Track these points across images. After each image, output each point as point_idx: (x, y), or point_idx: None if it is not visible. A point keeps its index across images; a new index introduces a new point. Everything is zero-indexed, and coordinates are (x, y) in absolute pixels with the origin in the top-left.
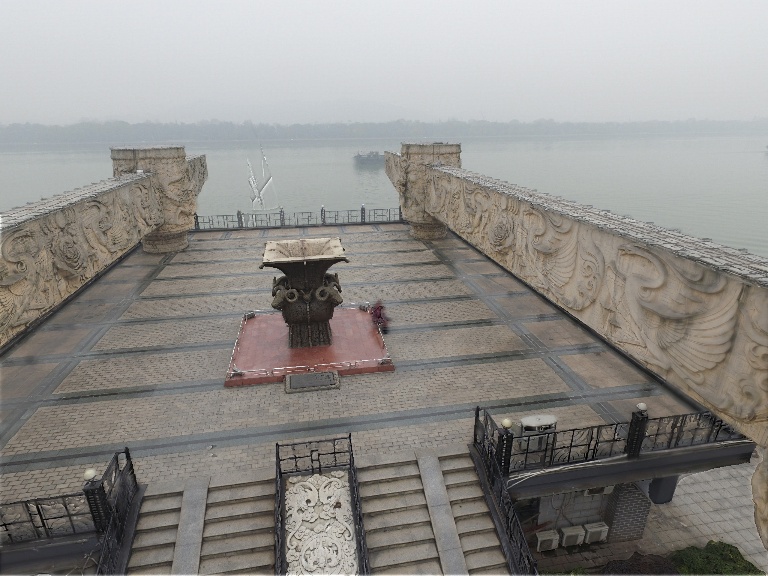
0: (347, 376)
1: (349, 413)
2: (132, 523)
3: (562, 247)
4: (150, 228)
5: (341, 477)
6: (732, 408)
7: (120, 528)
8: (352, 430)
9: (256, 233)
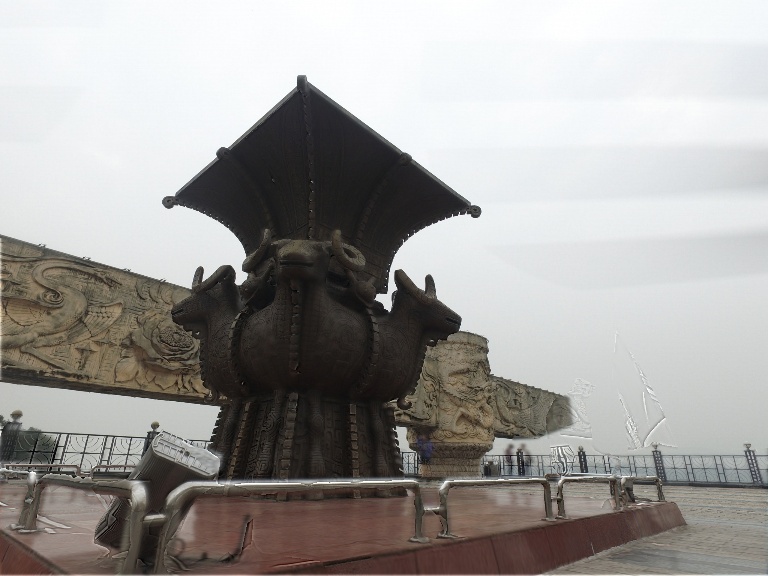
0: None
1: None
2: None
3: None
4: None
5: None
6: None
7: None
8: None
9: None
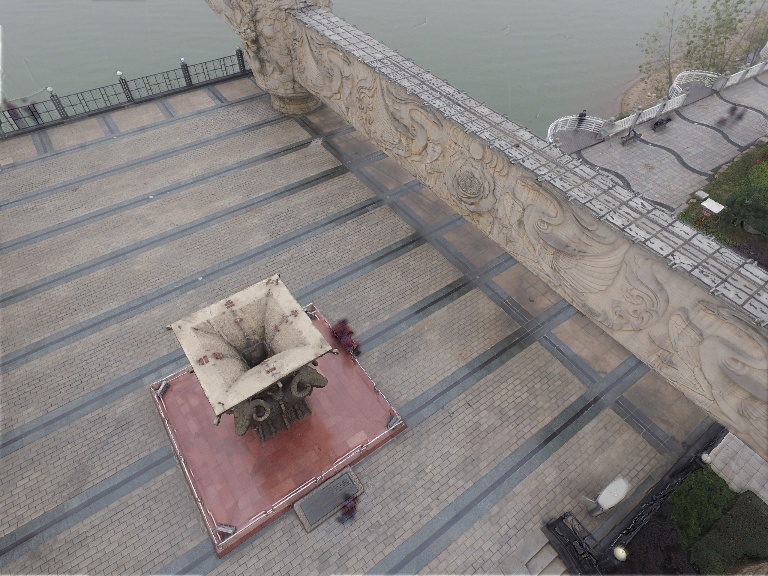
0: (360, 463)
1: (401, 535)
2: None
3: (594, 256)
4: None
5: None
6: None
7: None
8: (421, 565)
9: (28, 146)
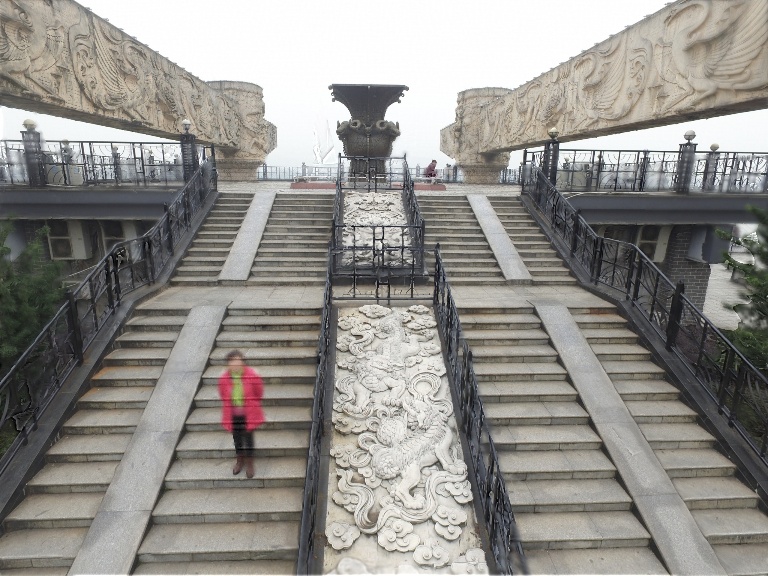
0: None
1: None
2: (212, 200)
3: (611, 67)
4: (228, 141)
5: (395, 194)
6: None
7: (203, 191)
8: None
9: None
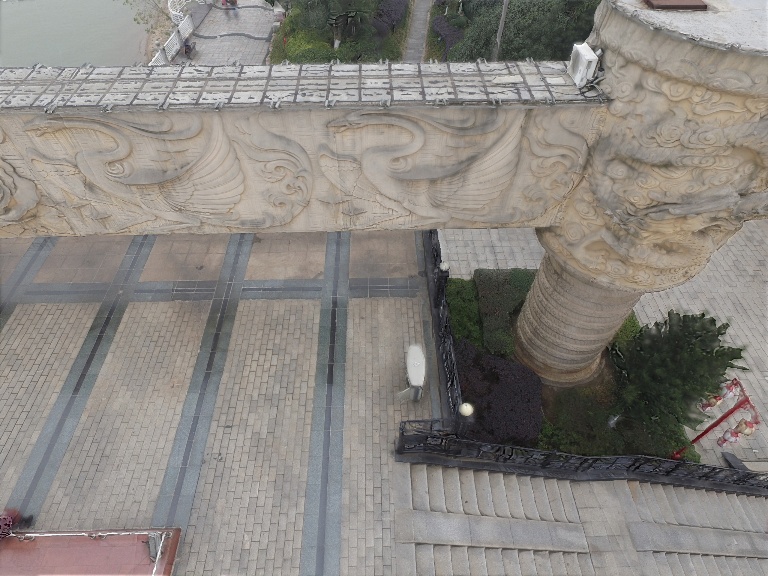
0: None
1: None
2: None
3: (199, 160)
4: None
5: None
6: (523, 216)
7: None
8: None
9: None
